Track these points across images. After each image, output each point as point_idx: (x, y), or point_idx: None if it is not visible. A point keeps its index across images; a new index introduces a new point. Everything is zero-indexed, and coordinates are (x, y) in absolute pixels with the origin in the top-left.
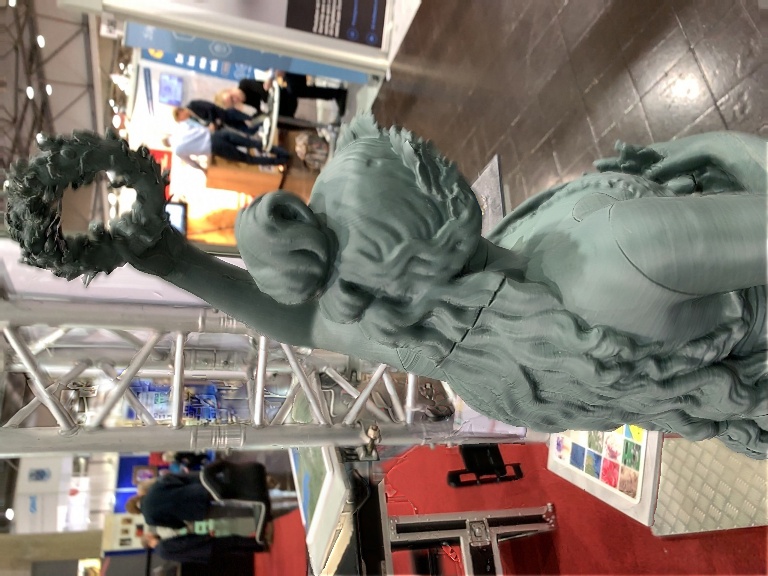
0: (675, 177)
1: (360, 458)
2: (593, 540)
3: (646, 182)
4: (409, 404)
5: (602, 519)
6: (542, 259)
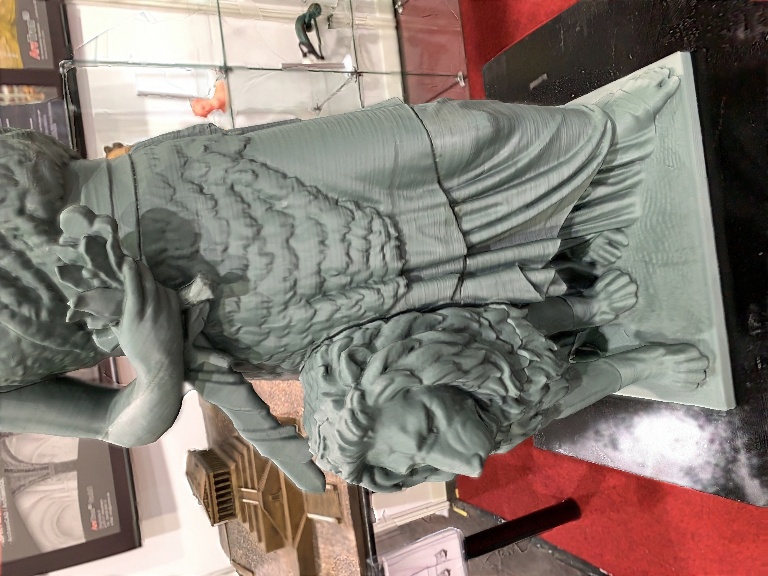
0: None
1: None
2: None
3: None
4: None
5: None
6: None
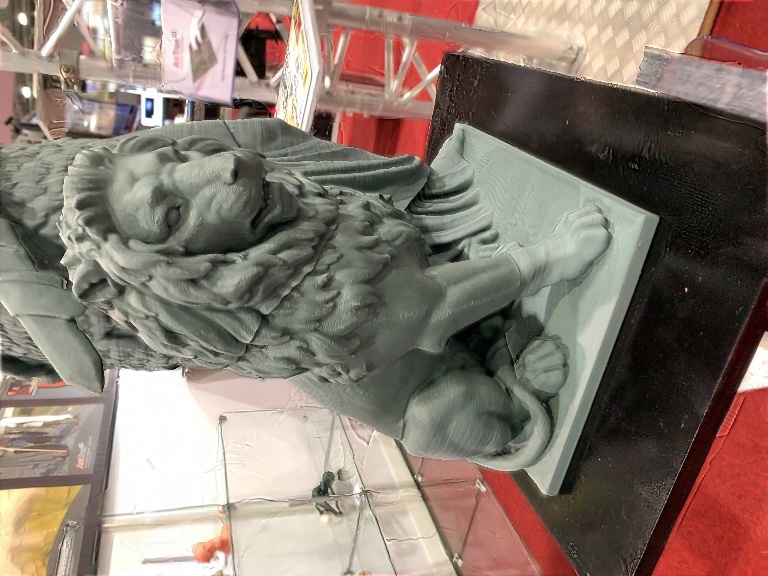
0: None
1: (62, 89)
2: (419, 139)
3: None
4: (112, 48)
5: None
6: None
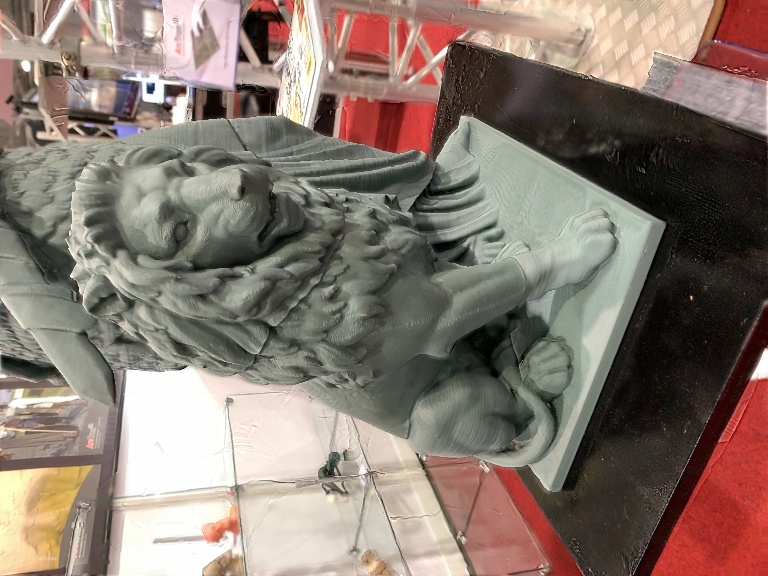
0: None
1: (63, 77)
2: (424, 119)
3: None
4: (113, 35)
5: (434, 106)
6: None
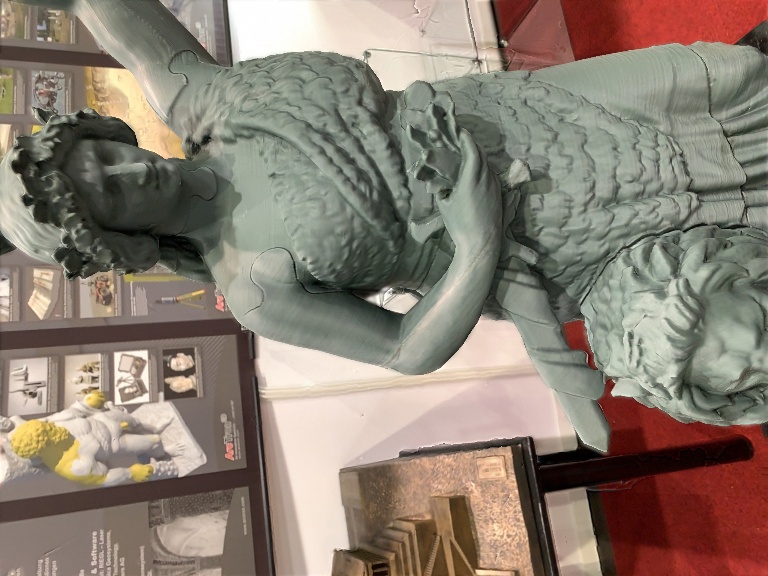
0: None
1: None
2: None
3: (341, 265)
4: None
5: None
6: (216, 264)
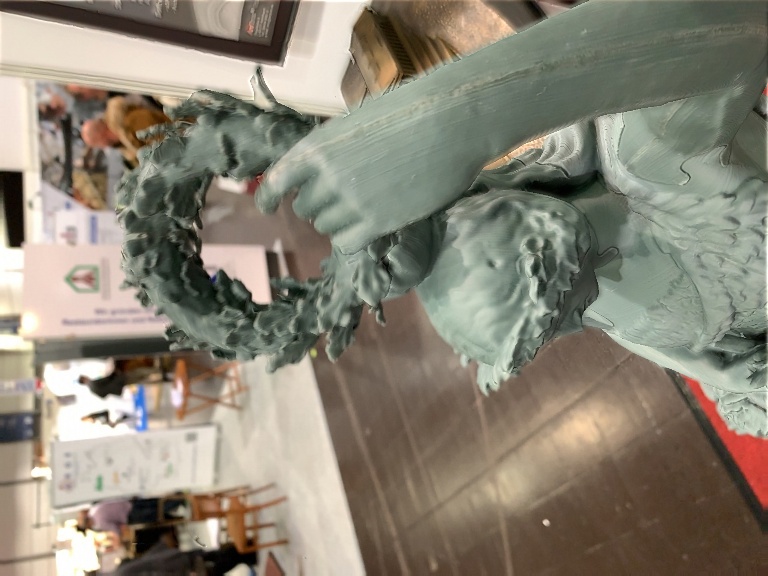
0: (748, 353)
1: None
2: None
3: None
4: None
5: None
6: None
